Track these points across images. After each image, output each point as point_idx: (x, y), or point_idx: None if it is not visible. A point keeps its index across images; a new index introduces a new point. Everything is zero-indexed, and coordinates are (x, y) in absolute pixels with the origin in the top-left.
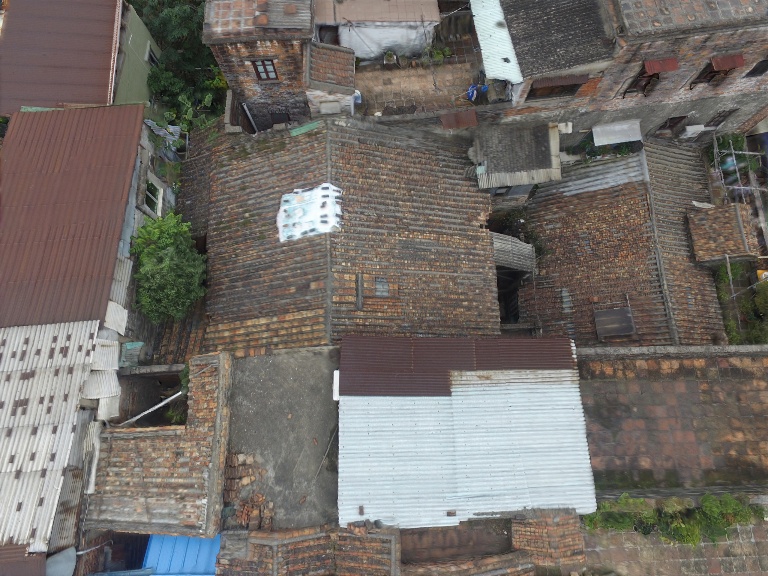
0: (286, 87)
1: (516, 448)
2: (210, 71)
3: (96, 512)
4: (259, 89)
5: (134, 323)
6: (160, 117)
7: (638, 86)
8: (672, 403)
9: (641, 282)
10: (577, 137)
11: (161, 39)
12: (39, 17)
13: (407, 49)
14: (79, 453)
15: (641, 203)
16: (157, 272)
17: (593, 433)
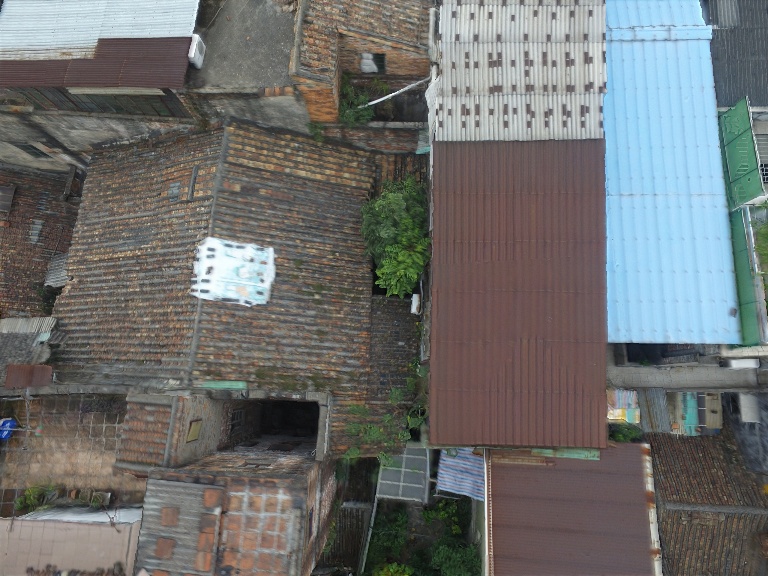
0: None
1: (59, 3)
2: None
3: None
4: None
5: None
6: None
7: None
8: None
9: None
10: None
11: None
12: None
13: None
14: None
15: None
16: None
17: None
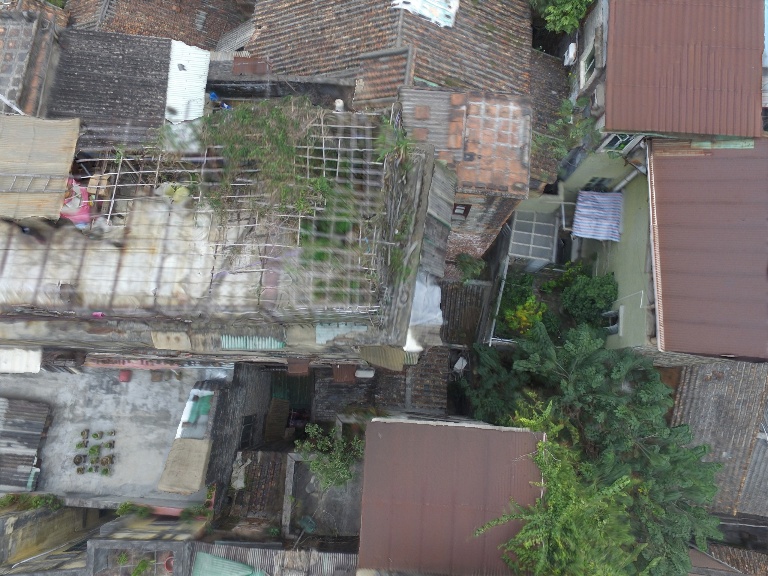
0: None
1: None
2: None
3: None
4: None
5: None
6: None
7: None
8: None
9: (129, 2)
10: None
11: (608, 370)
12: (764, 276)
13: None
14: None
15: None
16: None
17: None
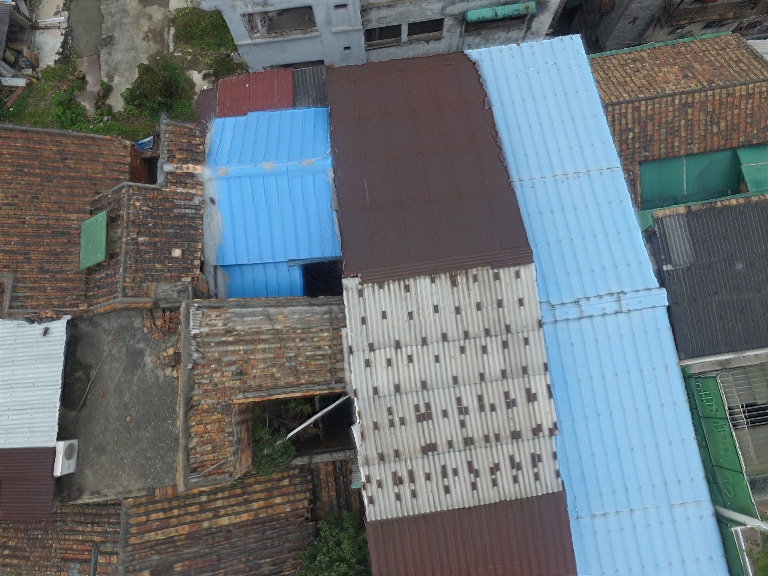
0: None
1: None
2: None
3: (336, 311)
4: None
5: None
6: None
7: None
8: None
9: None
10: None
11: None
12: None
13: None
14: None
15: None
16: None
17: None
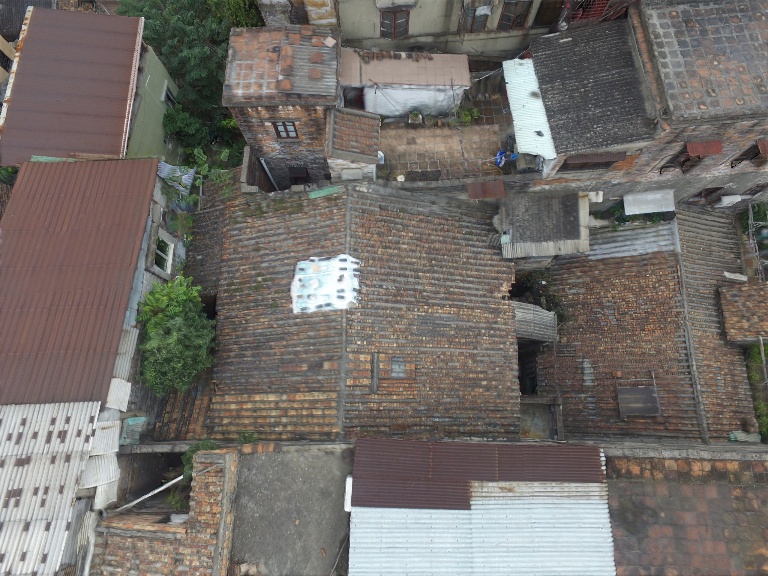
0: (306, 145)
1: (538, 571)
2: (227, 109)
3: None
4: (278, 146)
5: (137, 394)
6: (174, 156)
7: (676, 161)
8: (702, 509)
9: (668, 360)
10: (606, 203)
11: (179, 76)
12: (55, 60)
13: (434, 109)
14: (73, 547)
15: (671, 275)
16: (164, 347)
17: (617, 539)
